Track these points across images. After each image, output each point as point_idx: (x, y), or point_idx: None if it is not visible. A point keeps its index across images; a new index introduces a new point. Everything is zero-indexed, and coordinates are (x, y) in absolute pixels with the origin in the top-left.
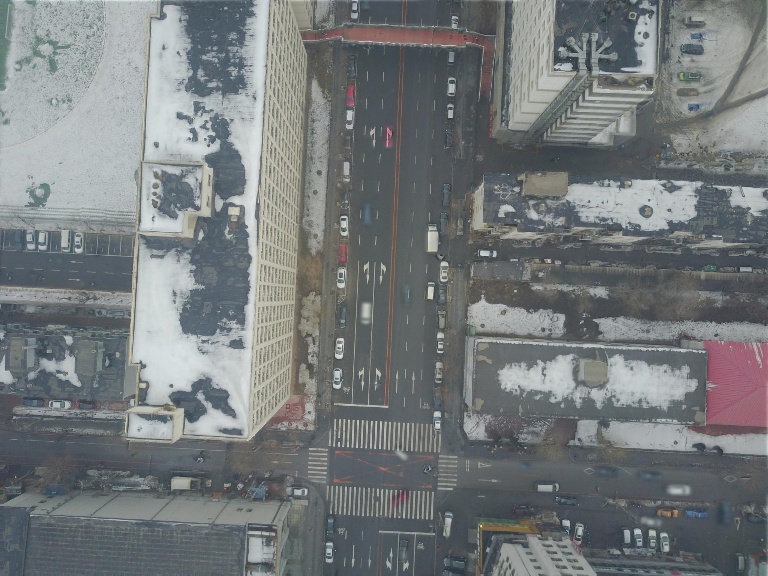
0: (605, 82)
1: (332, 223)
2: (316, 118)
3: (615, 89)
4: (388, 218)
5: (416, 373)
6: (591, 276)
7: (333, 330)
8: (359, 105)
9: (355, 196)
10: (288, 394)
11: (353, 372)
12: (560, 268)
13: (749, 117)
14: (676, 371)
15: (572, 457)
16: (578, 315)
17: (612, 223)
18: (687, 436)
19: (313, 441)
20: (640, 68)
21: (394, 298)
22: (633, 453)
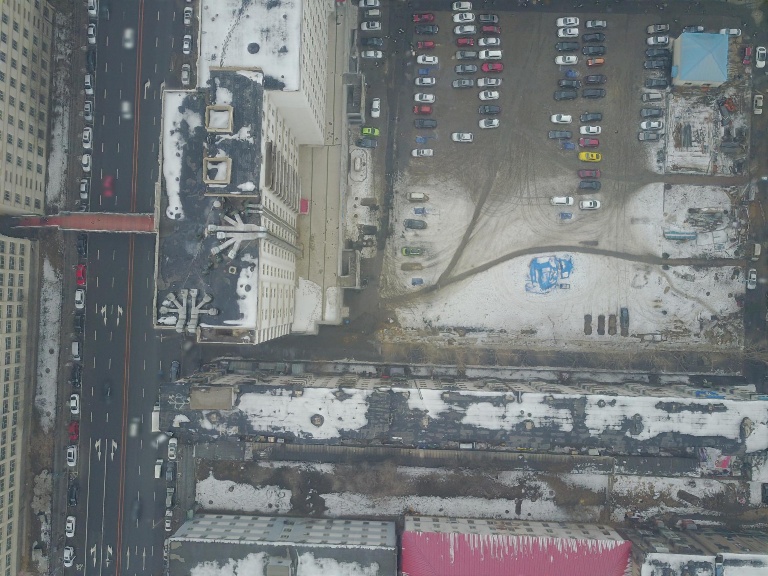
0: (210, 334)
1: (64, 401)
2: (48, 297)
3: (219, 341)
4: (119, 395)
5: (147, 549)
6: (312, 455)
7: (65, 507)
8: (91, 283)
9: (87, 373)
10: None
11: (85, 549)
12: (281, 447)
13: (472, 291)
14: (365, 568)
15: None
16: (304, 491)
17: (285, 432)
18: None
19: None
20: (242, 321)
21: (125, 475)
22: None
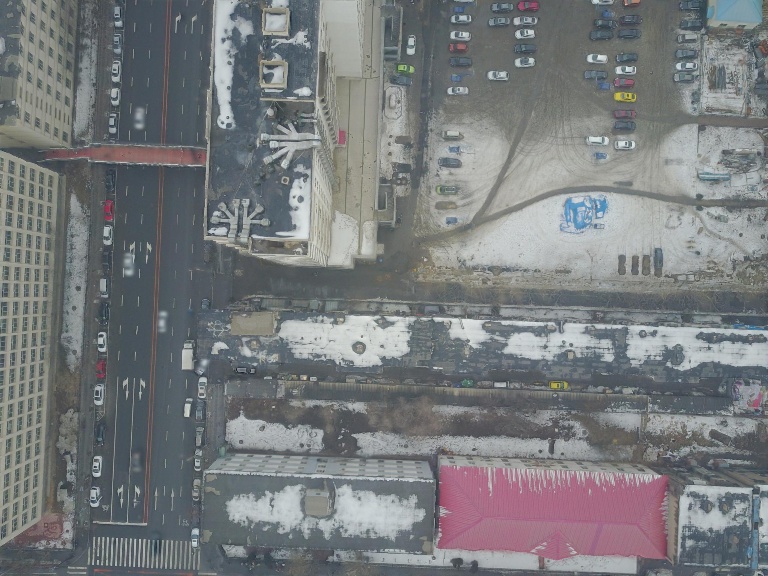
0: (261, 246)
1: (91, 339)
2: (75, 233)
3: (270, 253)
4: (148, 333)
5: (175, 490)
6: (345, 393)
7: (91, 447)
8: (119, 220)
9: (115, 311)
10: (35, 518)
11: (112, 489)
12: (314, 385)
13: (507, 230)
14: (404, 501)
15: (330, 573)
16: (336, 430)
17: (326, 359)
18: (445, 551)
19: (71, 560)
20: (294, 232)
21: (153, 414)
22: (391, 569)
